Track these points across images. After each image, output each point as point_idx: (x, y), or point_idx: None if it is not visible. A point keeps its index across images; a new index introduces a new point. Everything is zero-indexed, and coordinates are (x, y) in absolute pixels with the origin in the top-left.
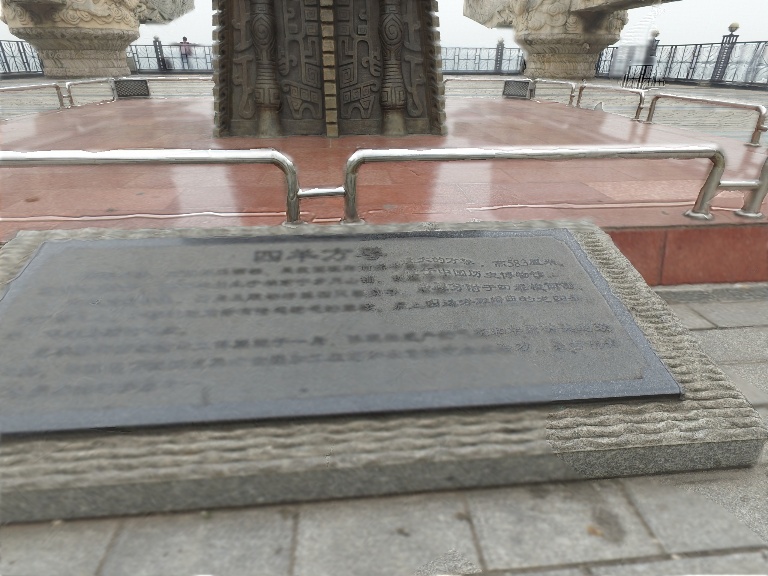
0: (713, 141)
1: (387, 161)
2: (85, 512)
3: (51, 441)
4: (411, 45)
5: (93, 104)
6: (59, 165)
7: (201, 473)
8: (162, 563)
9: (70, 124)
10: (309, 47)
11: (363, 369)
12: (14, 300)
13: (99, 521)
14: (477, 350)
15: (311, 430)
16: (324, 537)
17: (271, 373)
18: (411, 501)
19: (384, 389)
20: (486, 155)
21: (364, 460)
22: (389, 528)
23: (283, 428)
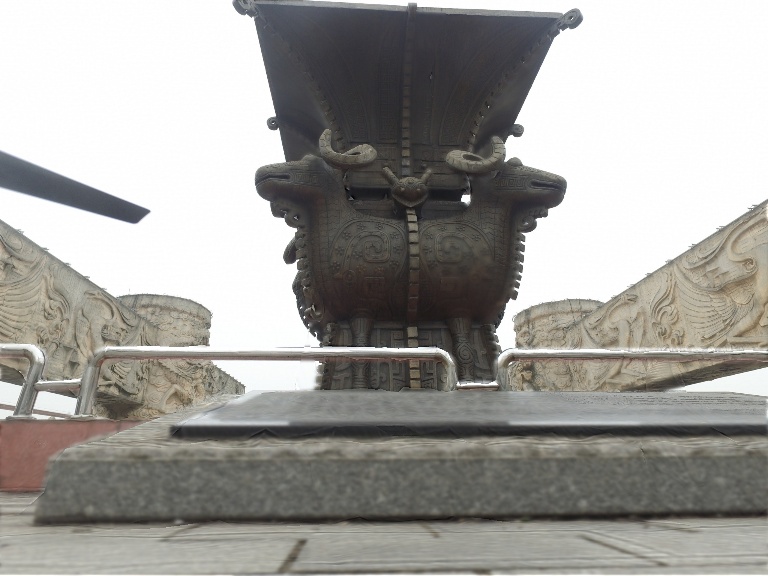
0: None
1: (532, 358)
2: (372, 516)
3: (339, 436)
4: (481, 365)
5: None
6: (260, 357)
7: (507, 462)
8: (506, 525)
9: None
10: (397, 367)
11: (623, 415)
12: (252, 397)
13: (393, 522)
14: (726, 413)
15: (607, 436)
16: (689, 524)
17: (531, 415)
18: (766, 516)
19: (659, 419)
20: (616, 354)
21: (684, 456)
22: (765, 523)
23: (574, 439)
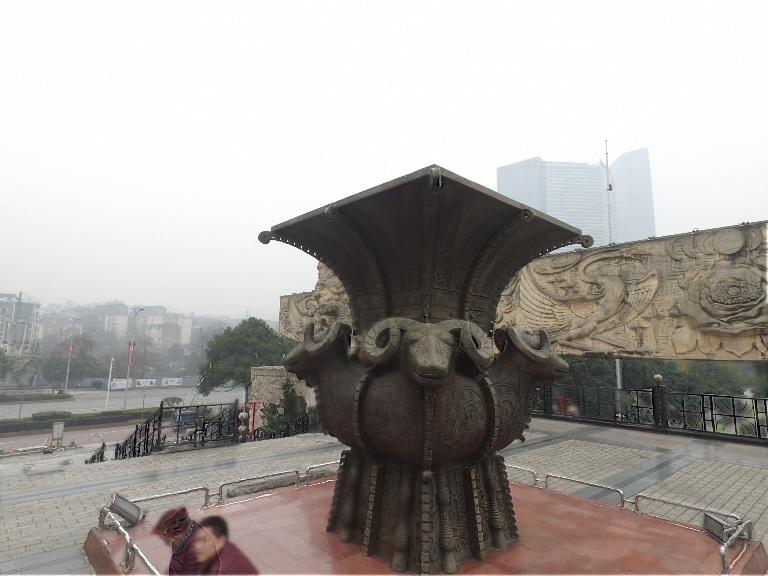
0: (150, 575)
1: None
2: None
3: None
4: None
5: (670, 521)
6: None
7: None
8: None
9: (517, 496)
10: None
11: None
12: None
13: None
14: None
15: None
16: None
17: None
18: None
19: None
20: None
21: None
22: None
23: None
